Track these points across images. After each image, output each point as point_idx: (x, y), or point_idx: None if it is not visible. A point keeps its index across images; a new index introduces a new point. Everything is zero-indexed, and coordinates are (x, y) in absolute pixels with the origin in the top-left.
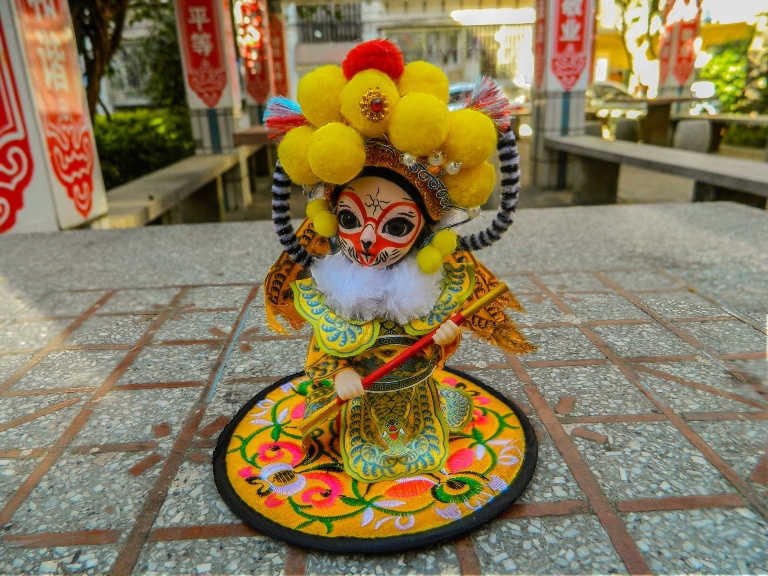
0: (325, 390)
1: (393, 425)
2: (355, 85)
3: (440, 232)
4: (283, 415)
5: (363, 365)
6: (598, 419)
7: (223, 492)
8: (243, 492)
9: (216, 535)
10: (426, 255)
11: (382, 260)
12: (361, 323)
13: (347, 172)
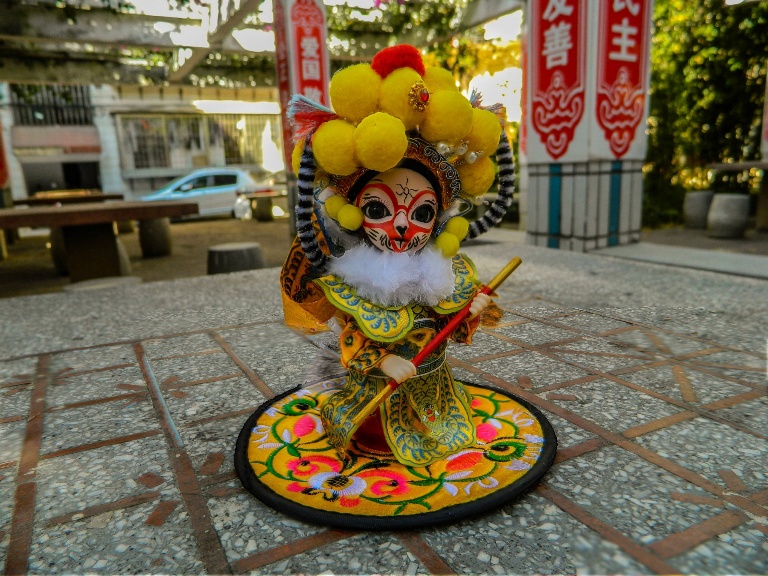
0: (342, 394)
1: (429, 408)
2: (400, 78)
3: (453, 219)
4: (288, 435)
5: (397, 352)
6: (557, 386)
7: (289, 508)
8: (311, 502)
9: (311, 547)
10: (448, 239)
11: (414, 245)
12: (398, 308)
13: (398, 157)
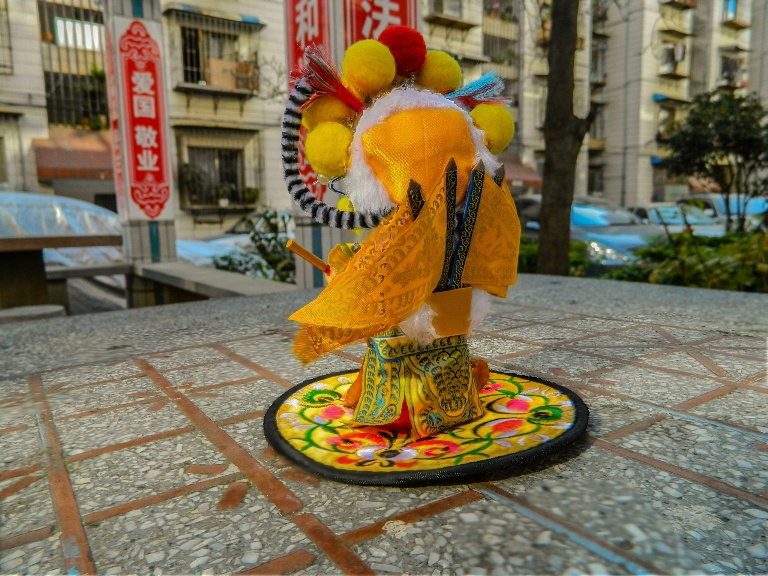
0: None
1: None
2: None
3: None
4: (524, 397)
5: None
6: (190, 487)
7: None
8: None
9: None
10: None
11: None
12: None
13: None
